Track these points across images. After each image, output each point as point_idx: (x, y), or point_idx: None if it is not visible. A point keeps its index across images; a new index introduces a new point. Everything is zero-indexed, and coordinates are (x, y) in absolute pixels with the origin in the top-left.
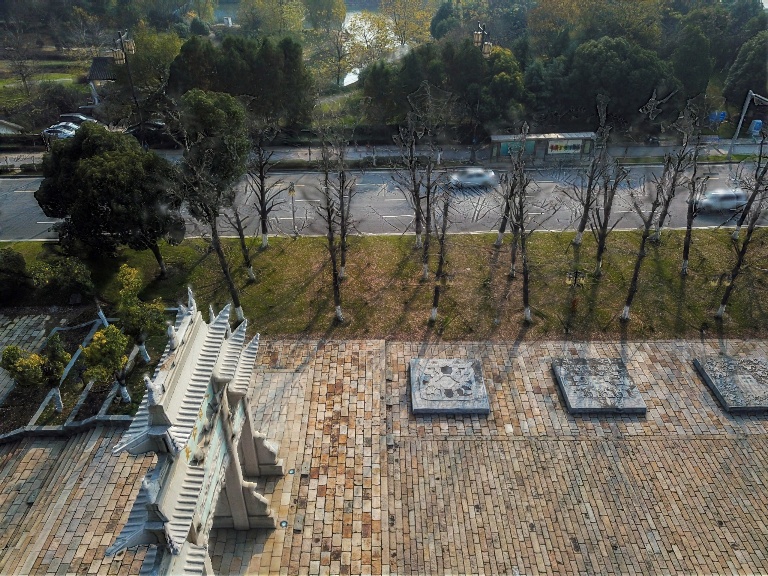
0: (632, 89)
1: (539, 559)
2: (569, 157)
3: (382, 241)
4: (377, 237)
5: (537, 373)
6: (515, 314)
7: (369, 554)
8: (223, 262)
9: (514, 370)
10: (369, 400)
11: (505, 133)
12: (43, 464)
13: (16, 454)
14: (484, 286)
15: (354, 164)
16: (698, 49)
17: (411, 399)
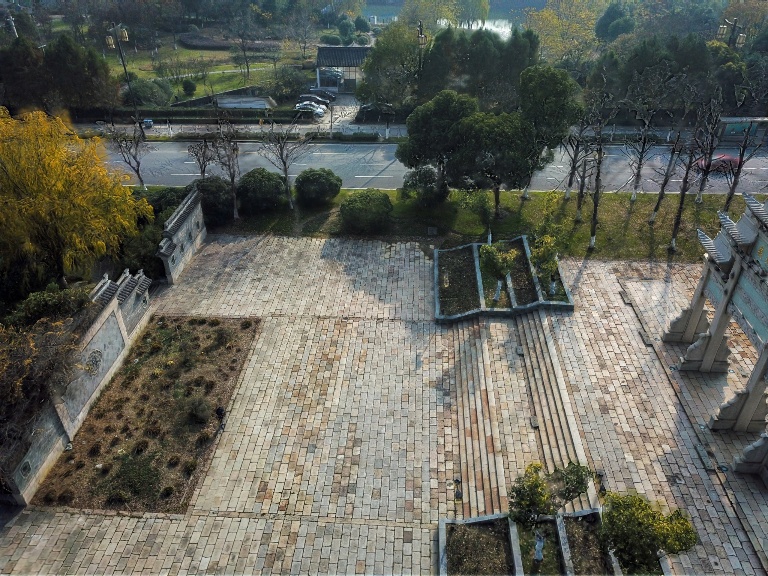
0: None
1: None
2: None
3: None
4: (656, 194)
5: None
6: None
7: None
8: (597, 197)
9: None
10: None
11: (730, 116)
12: (508, 332)
13: (482, 326)
14: None
15: (594, 139)
16: None
17: None
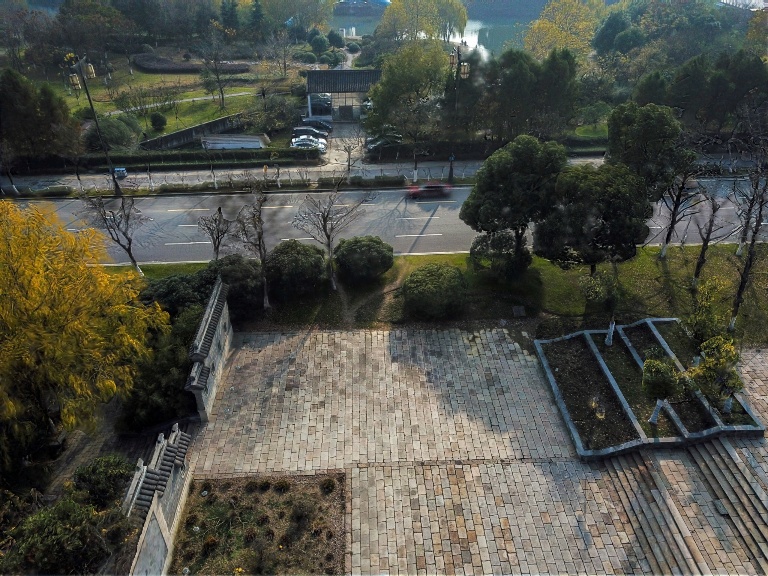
0: None
1: None
2: None
3: None
4: (759, 245)
5: None
6: None
7: None
8: (747, 272)
9: None
10: None
11: None
12: (689, 476)
13: (651, 467)
14: None
15: None
16: None
17: None
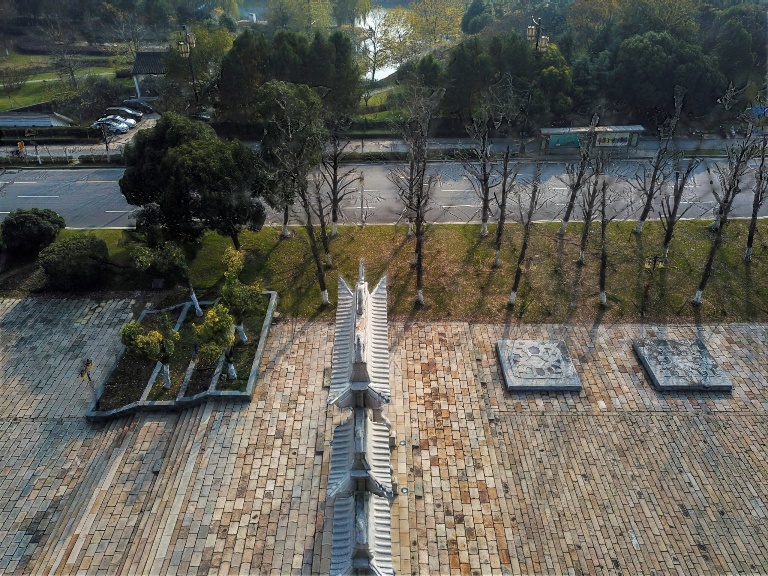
0: (678, 83)
1: (652, 523)
2: (616, 150)
3: (447, 230)
4: (441, 226)
5: (620, 354)
6: (589, 298)
7: (490, 518)
8: (314, 247)
9: (597, 351)
10: (464, 378)
11: (554, 126)
12: (160, 436)
13: (132, 427)
14: (555, 272)
15: None
16: (740, 44)
17: (504, 377)
